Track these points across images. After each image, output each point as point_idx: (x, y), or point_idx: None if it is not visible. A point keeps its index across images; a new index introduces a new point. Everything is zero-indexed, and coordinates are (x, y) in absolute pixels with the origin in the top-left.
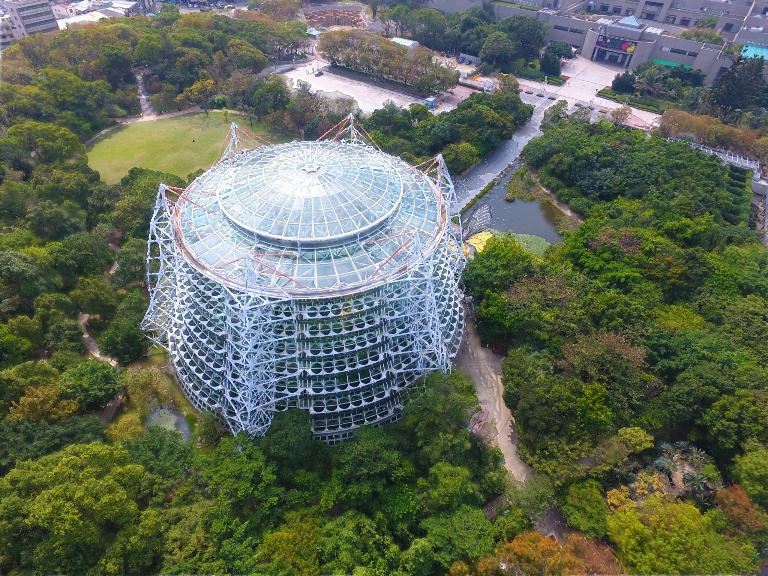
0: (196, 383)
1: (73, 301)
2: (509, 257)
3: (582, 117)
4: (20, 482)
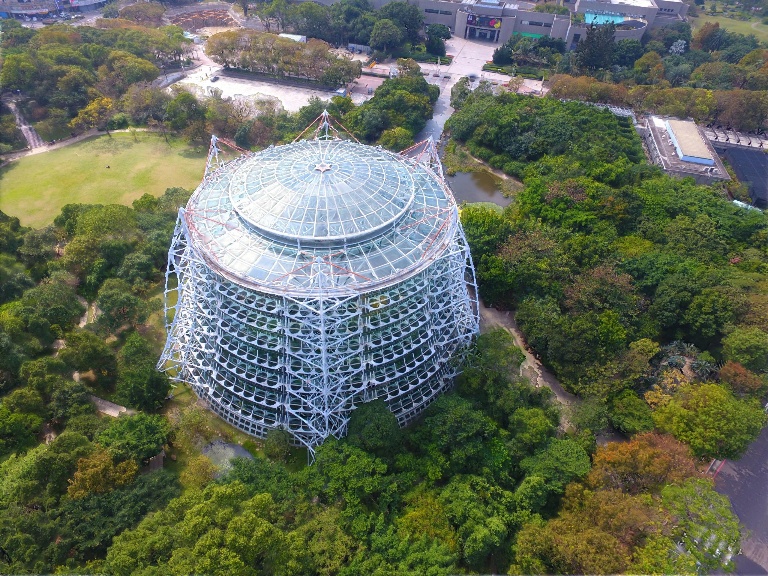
0: (244, 409)
1: (66, 361)
2: (488, 223)
3: (485, 90)
4: (139, 552)
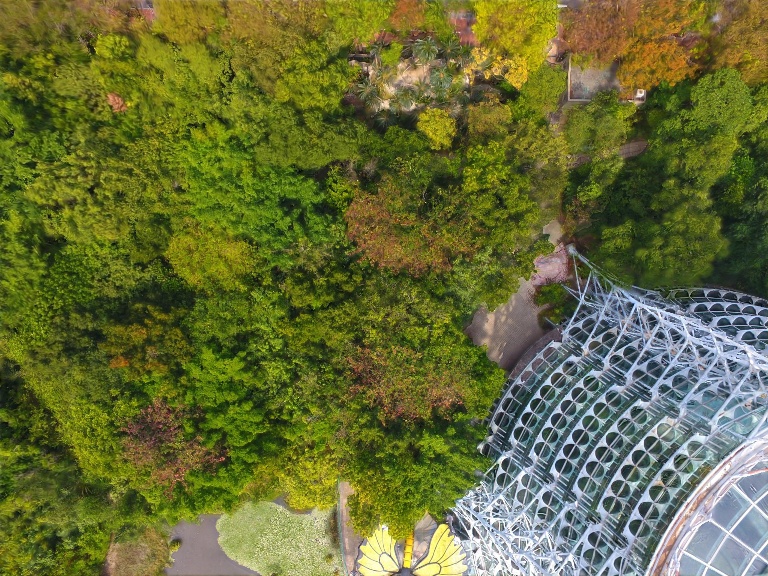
0: None
1: None
2: None
3: None
4: None
